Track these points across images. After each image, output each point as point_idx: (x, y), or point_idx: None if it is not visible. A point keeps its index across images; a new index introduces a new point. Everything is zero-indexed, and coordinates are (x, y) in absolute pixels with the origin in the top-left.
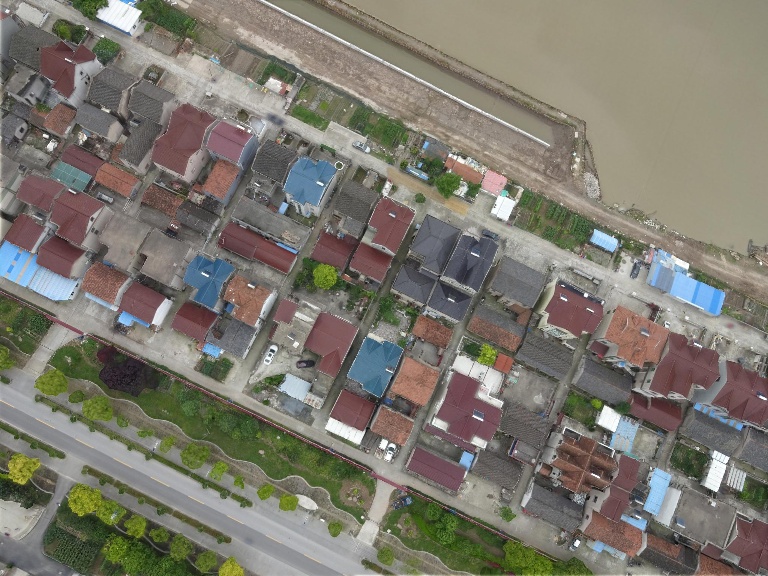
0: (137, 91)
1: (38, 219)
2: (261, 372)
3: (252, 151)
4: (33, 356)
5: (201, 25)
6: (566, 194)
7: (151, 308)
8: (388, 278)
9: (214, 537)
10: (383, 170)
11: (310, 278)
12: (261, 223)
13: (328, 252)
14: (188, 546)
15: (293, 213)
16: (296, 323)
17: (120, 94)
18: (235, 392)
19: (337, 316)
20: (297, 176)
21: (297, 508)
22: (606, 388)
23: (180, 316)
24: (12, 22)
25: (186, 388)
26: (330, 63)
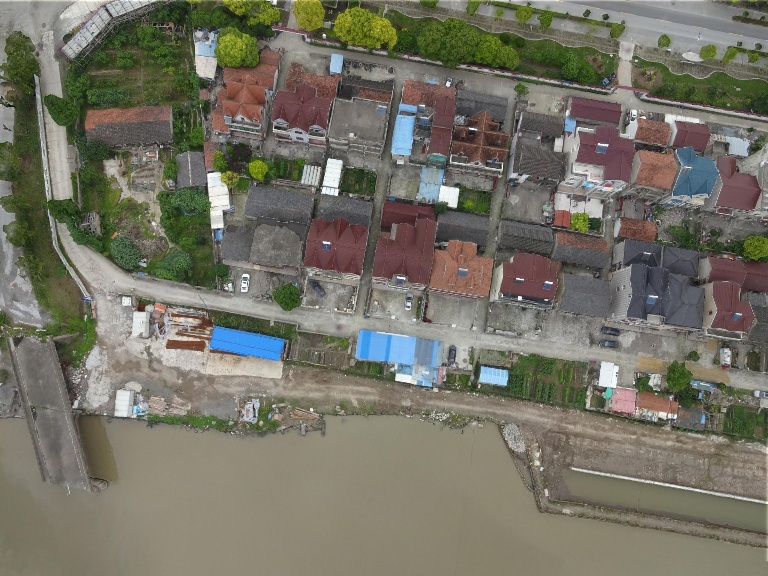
0: None
1: None
2: (764, 154)
3: None
4: None
5: None
6: (540, 419)
7: None
8: None
9: None
10: (733, 378)
11: None
12: None
13: (762, 272)
14: None
15: None
16: None
17: None
18: None
19: (731, 215)
20: None
21: None
22: (463, 222)
23: None
24: None
25: None
26: None
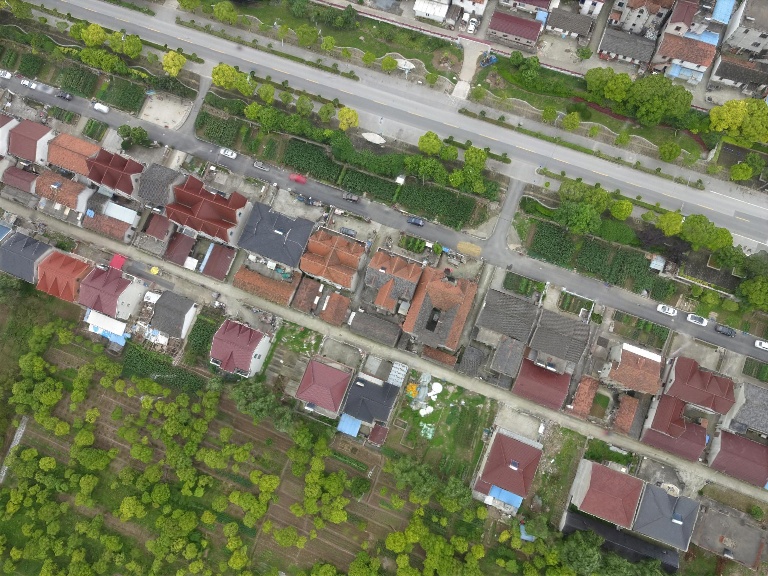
0: None
1: None
2: None
3: None
4: None
5: None
6: None
7: None
8: None
9: None
10: None
11: None
12: None
13: None
14: None
15: None
16: None
17: None
18: None
19: None
20: None
21: (397, 78)
22: None
23: None
24: None
25: None
26: None
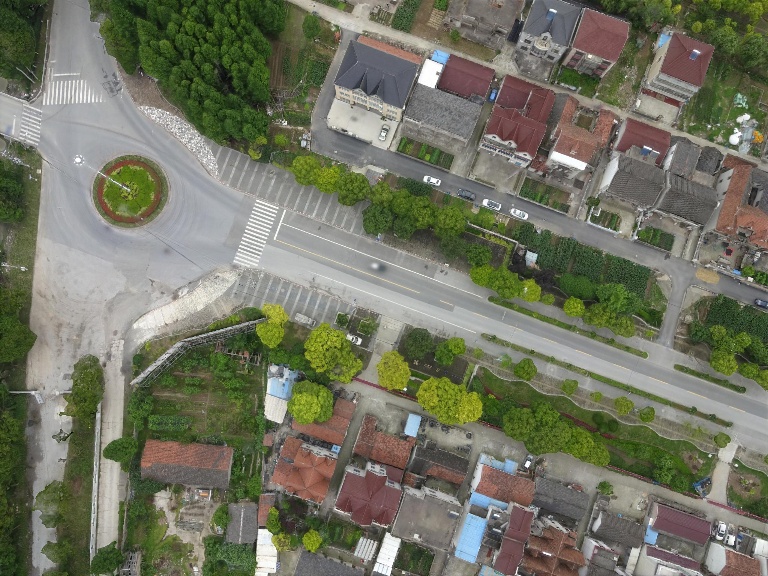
0: None
1: None
2: None
3: None
4: None
5: None
6: None
7: None
8: None
9: None
10: None
11: None
12: None
13: None
14: None
15: None
16: None
17: None
18: None
19: None
20: None
21: None
22: None
23: None
24: None
25: None
26: None
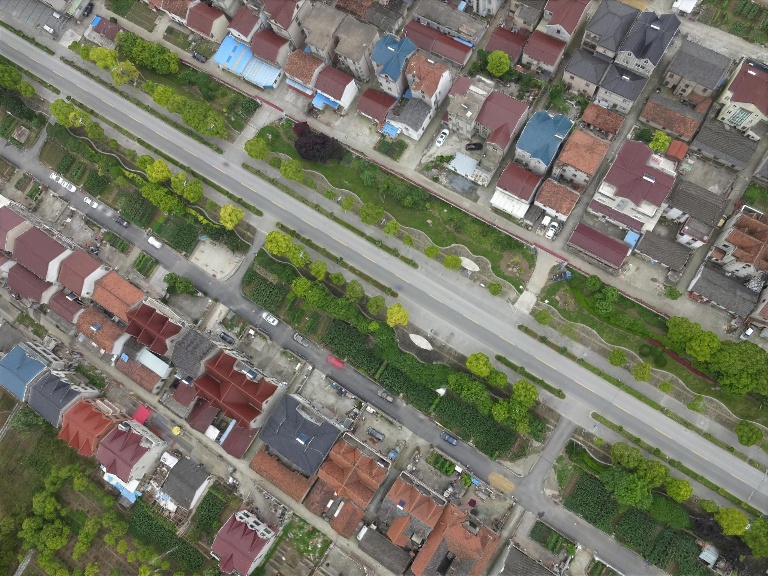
0: None
1: (254, 10)
2: (432, 153)
3: None
4: (242, 133)
5: None
6: None
7: (341, 85)
8: (559, 71)
9: (383, 291)
10: None
11: (483, 69)
12: (440, 19)
13: (502, 42)
14: (361, 291)
15: (470, 13)
16: (470, 95)
17: None
18: (408, 170)
19: None
20: None
21: (459, 273)
22: None
23: (365, 97)
24: None
25: (366, 162)
26: None
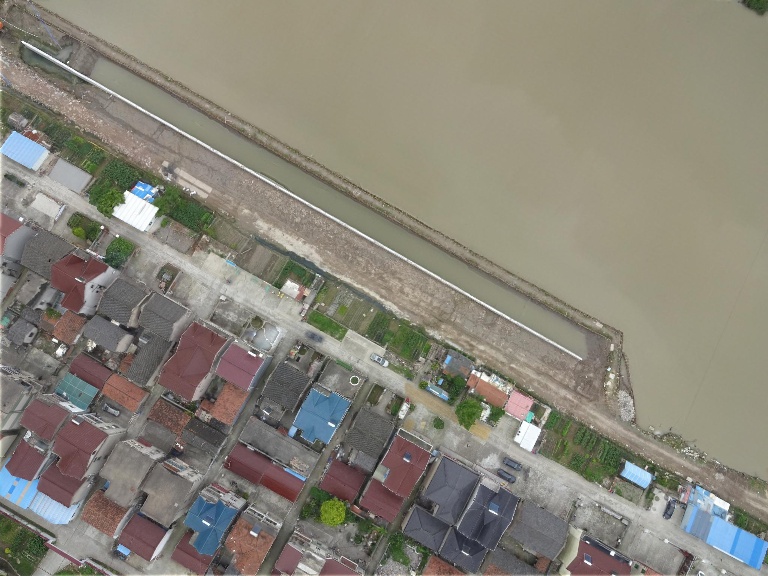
0: (147, 309)
1: (40, 448)
2: None
3: (264, 368)
4: None
5: (219, 218)
6: (597, 415)
7: (150, 547)
8: None
9: None
10: (401, 386)
11: (317, 508)
12: (269, 447)
13: (337, 484)
14: None
15: None
16: (298, 575)
17: (130, 311)
18: None
19: (343, 557)
20: (308, 414)
21: None
22: None
23: (180, 550)
24: (25, 228)
25: None
26: (351, 260)
